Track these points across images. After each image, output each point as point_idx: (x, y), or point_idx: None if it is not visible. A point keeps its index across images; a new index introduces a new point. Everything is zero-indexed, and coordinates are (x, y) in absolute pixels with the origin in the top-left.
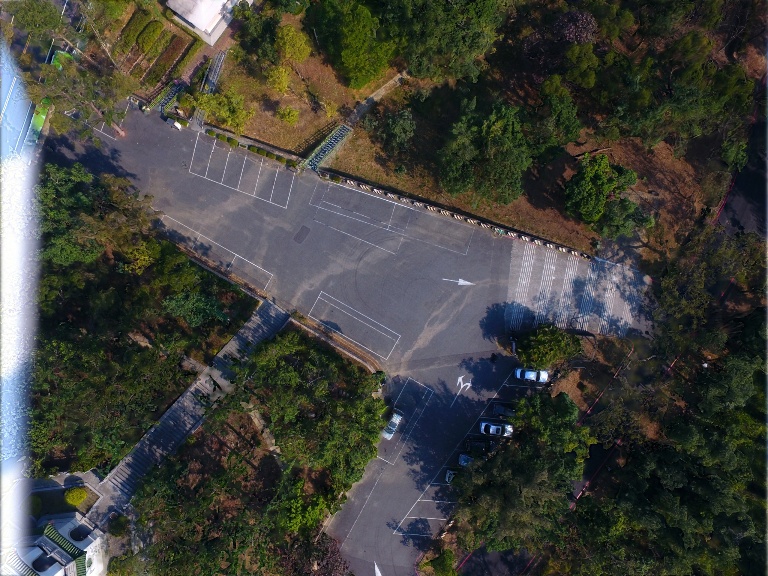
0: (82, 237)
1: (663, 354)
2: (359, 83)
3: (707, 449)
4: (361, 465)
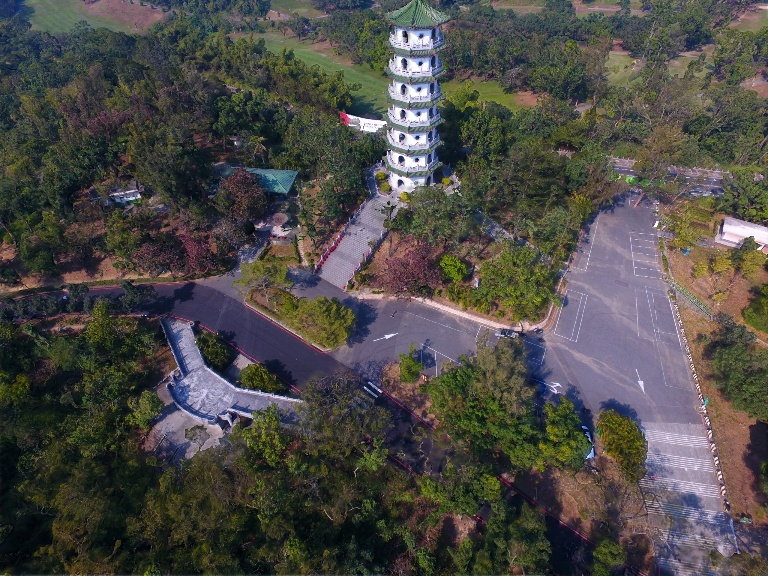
0: (590, 166)
1: None
2: (751, 320)
3: (608, 573)
4: (494, 291)
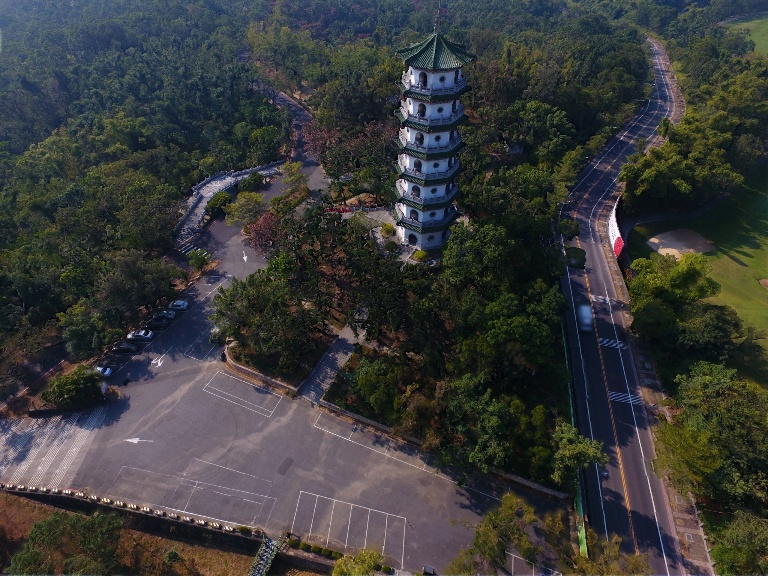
0: None
1: None
2: None
3: None
4: None
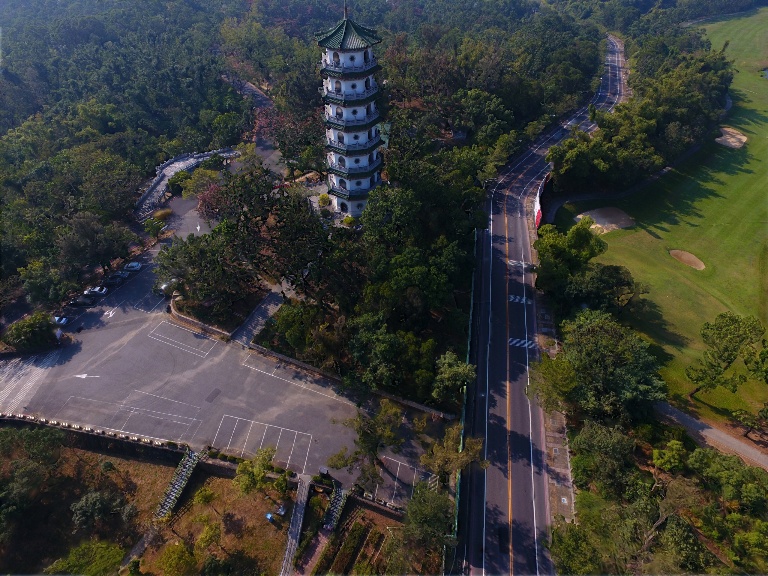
0: None
1: None
2: (130, 575)
3: None
4: None
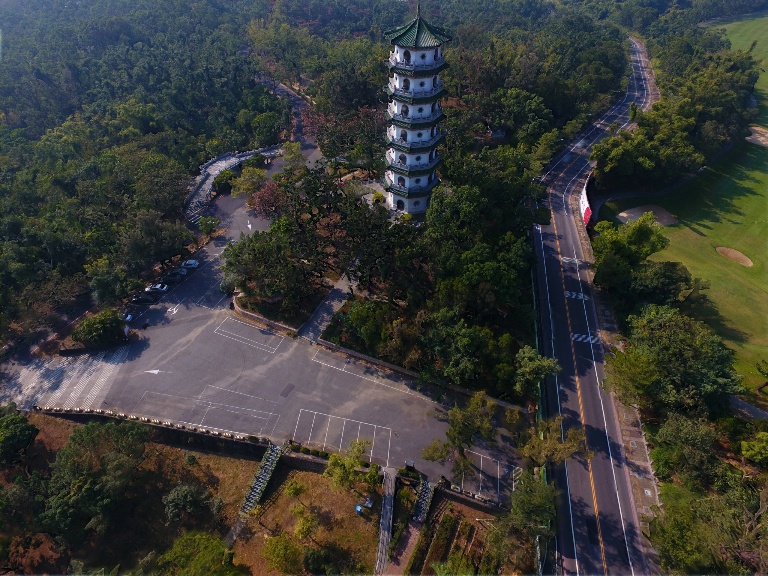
0: None
1: (8, 352)
2: None
3: None
4: None
